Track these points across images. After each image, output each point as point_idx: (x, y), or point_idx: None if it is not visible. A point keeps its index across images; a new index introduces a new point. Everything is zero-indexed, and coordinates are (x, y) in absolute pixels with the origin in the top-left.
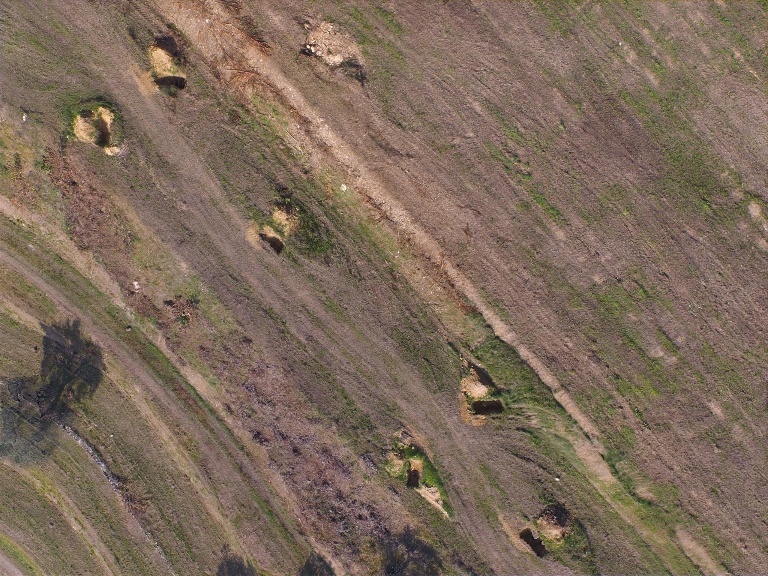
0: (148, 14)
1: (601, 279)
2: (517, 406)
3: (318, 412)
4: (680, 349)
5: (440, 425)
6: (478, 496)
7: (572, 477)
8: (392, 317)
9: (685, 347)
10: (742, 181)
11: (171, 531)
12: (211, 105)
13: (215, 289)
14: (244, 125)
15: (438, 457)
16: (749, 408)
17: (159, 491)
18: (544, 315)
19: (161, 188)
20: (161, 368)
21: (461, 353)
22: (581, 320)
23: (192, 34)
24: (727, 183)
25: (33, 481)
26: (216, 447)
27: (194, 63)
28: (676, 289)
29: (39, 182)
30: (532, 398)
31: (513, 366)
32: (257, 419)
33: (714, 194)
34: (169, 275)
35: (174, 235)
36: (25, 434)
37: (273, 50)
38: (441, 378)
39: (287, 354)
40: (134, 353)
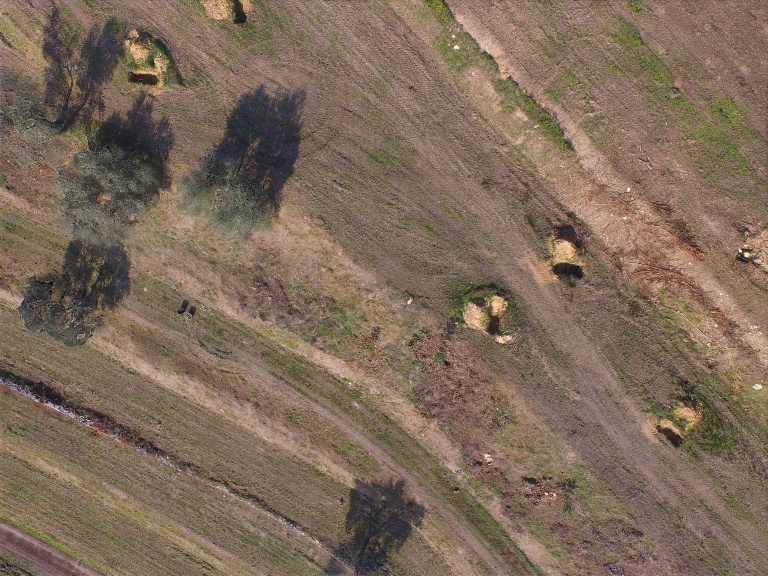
0: (546, 202)
1: None
2: None
3: None
4: None
5: None
6: None
7: None
8: None
9: None
10: None
11: None
12: (611, 296)
13: (607, 481)
14: (645, 317)
15: None
16: None
17: None
18: None
19: (553, 377)
20: (489, 531)
21: None
22: None
23: (596, 225)
24: None
25: None
26: None
27: (594, 252)
28: None
29: (395, 354)
30: None
31: None
32: None
33: None
34: (543, 458)
35: (565, 425)
36: None
37: (706, 255)
38: None
39: (682, 549)
40: (461, 515)
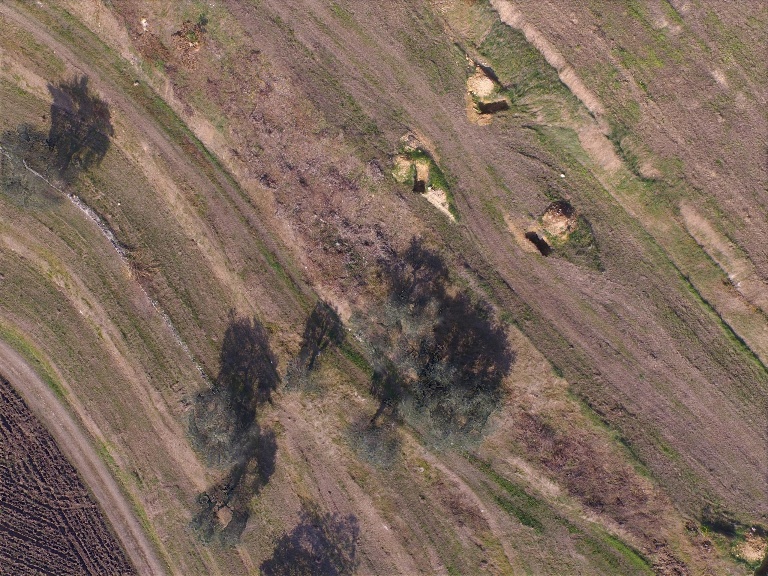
0: None
1: None
2: (523, 102)
3: (325, 120)
4: (684, 18)
5: (446, 127)
6: (484, 198)
7: (577, 173)
8: (399, 20)
9: (689, 16)
10: None
11: (178, 298)
12: None
13: None
14: None
15: (444, 160)
16: (752, 74)
17: (166, 258)
18: None
19: None
20: (168, 123)
21: (467, 54)
22: None
23: None
24: None
25: (40, 265)
26: (223, 201)
27: None
28: None
29: None
30: (538, 86)
31: (519, 51)
32: (264, 157)
33: None
34: None
35: None
36: (33, 212)
37: None
38: (447, 79)
39: (295, 63)
40: (142, 108)
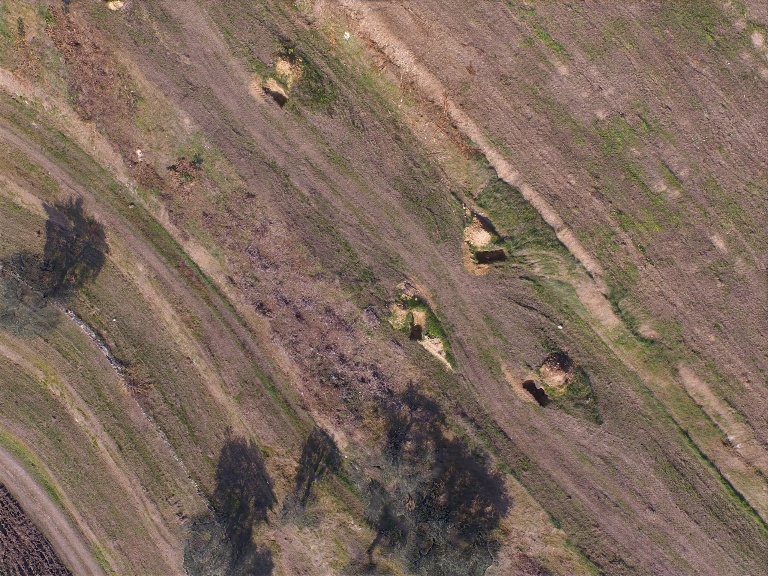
0: None
1: (604, 114)
2: (520, 254)
3: (321, 266)
4: (683, 183)
5: (443, 276)
6: (481, 347)
7: (575, 325)
8: (395, 168)
9: (688, 180)
10: (745, 11)
11: (174, 415)
12: None
13: (218, 144)
14: None
15: (441, 308)
16: (752, 240)
17: (162, 375)
18: (547, 152)
19: (164, 42)
20: (164, 245)
21: (464, 203)
22: (584, 156)
23: None
24: (730, 13)
25: (36, 373)
26: (219, 324)
27: None
28: (679, 122)
29: (42, 49)
30: (535, 241)
31: (516, 208)
32: (260, 288)
33: (717, 25)
34: (172, 136)
35: (177, 90)
36: None
37: None
38: (444, 228)
39: (290, 208)
40: (137, 230)
